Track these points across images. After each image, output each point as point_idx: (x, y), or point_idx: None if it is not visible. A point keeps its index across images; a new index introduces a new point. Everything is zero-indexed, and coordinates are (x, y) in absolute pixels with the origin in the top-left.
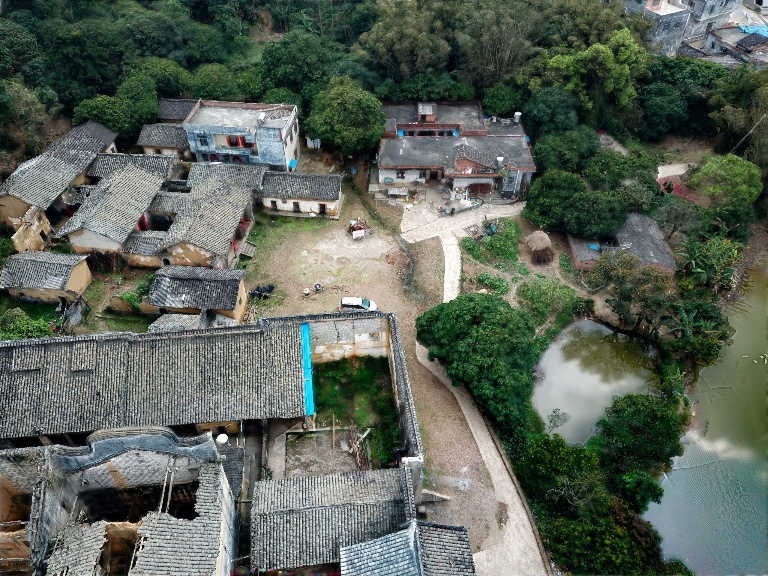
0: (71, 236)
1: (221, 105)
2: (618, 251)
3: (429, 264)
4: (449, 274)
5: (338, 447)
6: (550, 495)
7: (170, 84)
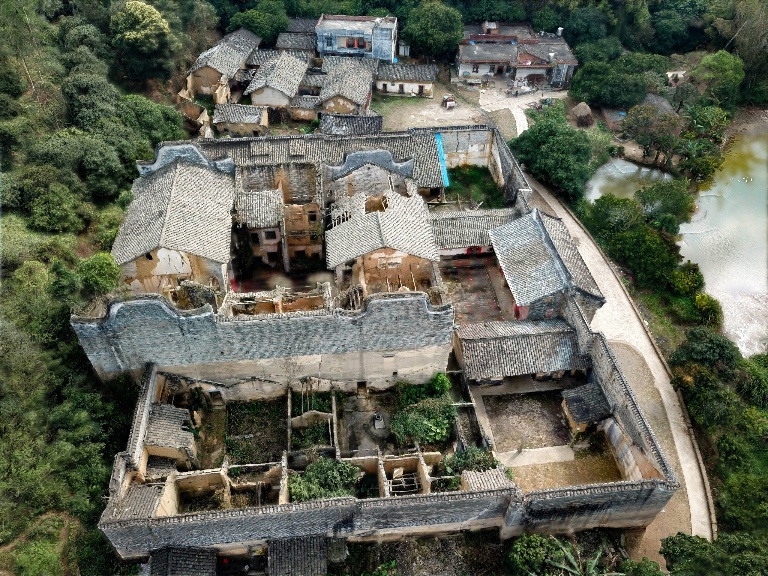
0: (253, 95)
1: (339, 18)
2: (643, 105)
3: (504, 123)
4: (520, 128)
5: (463, 210)
6: (609, 219)
7: (293, 7)
